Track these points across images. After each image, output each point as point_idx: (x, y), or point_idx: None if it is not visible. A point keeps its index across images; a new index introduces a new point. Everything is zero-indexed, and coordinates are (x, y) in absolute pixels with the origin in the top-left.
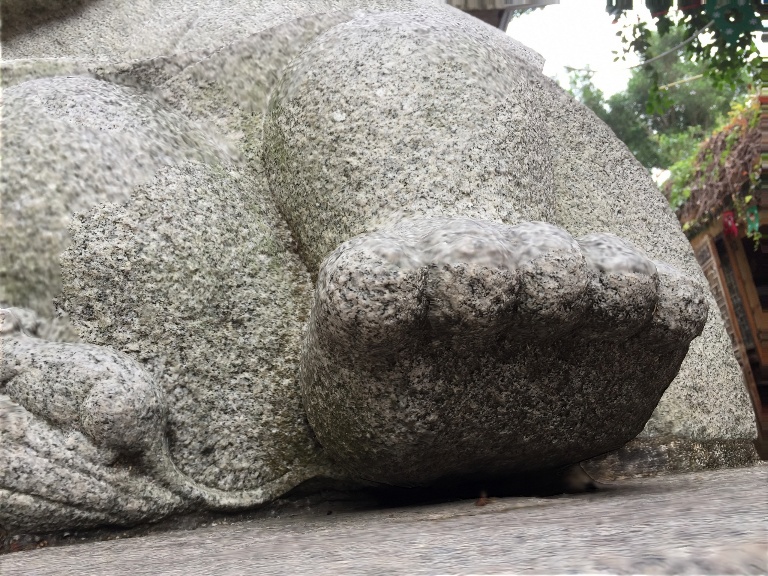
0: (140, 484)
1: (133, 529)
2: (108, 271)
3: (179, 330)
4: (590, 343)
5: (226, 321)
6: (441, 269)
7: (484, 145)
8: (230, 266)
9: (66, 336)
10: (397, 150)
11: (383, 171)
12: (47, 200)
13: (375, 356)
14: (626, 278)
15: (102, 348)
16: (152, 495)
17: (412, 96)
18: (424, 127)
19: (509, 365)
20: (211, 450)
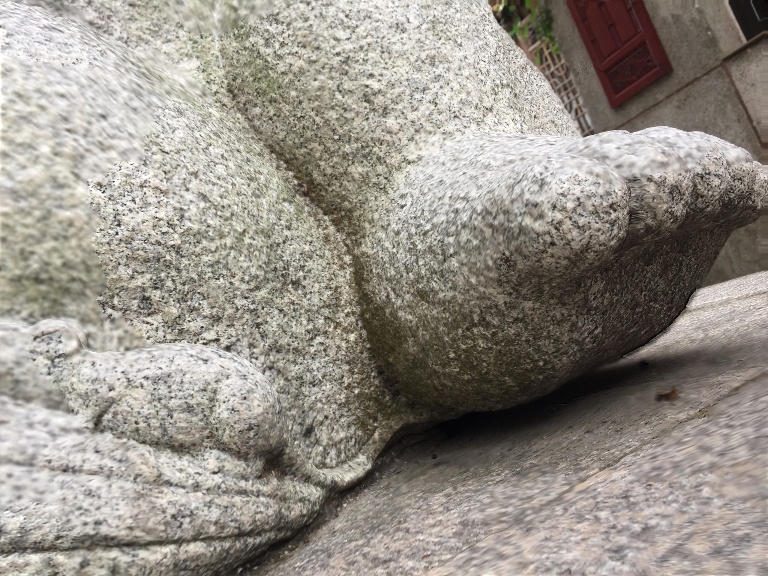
0: (290, 487)
1: (294, 538)
2: (156, 250)
3: (250, 305)
4: (698, 233)
5: (286, 284)
6: (646, 181)
7: (486, 57)
8: (269, 221)
9: (128, 342)
10: (417, 68)
11: (409, 92)
12: (44, 168)
13: (570, 281)
14: (746, 168)
15: (190, 345)
16: (304, 494)
17: (413, 7)
18: (435, 41)
19: (651, 266)
20: (311, 429)
